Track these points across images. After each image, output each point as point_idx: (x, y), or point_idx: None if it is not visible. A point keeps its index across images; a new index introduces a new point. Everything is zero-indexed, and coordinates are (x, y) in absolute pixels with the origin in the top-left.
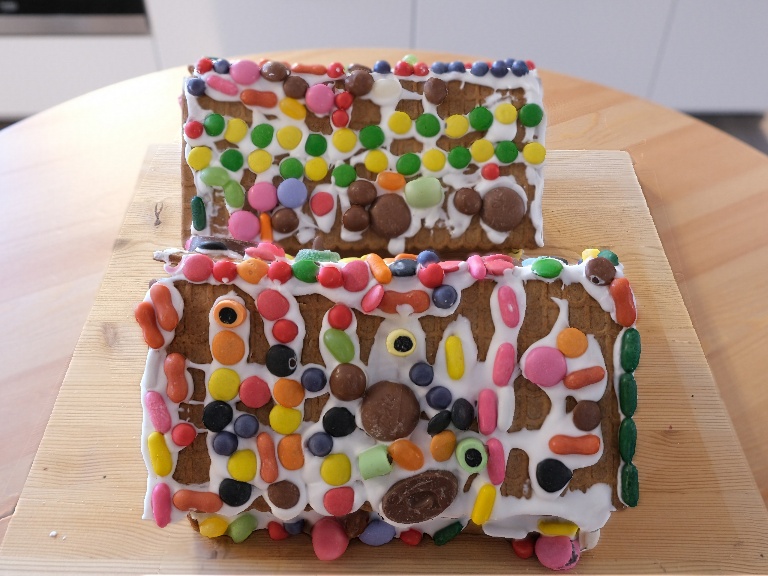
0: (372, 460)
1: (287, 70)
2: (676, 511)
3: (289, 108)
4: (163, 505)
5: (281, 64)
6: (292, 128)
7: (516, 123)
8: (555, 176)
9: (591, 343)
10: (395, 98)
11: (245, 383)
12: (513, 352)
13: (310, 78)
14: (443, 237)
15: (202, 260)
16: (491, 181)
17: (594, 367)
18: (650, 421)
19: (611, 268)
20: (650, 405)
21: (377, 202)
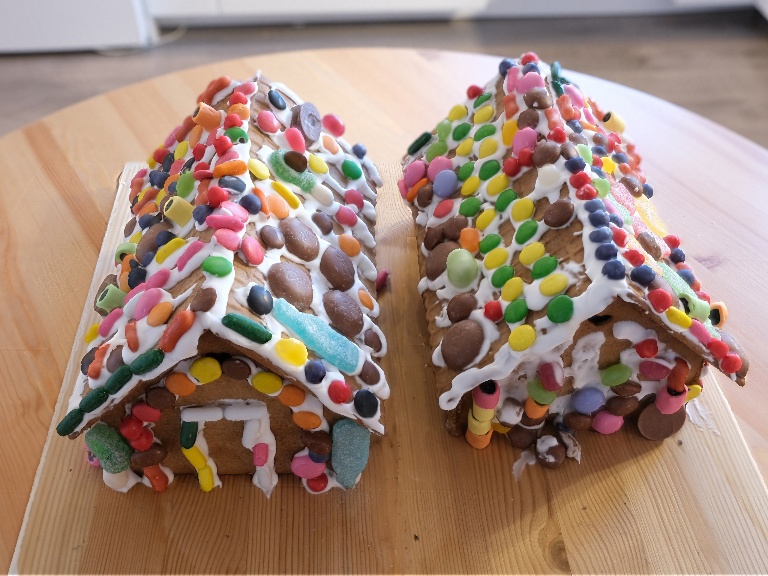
0: (123, 245)
1: (537, 102)
2: (138, 574)
3: (504, 126)
4: (137, 177)
5: (541, 95)
6: (494, 144)
7: (549, 301)
8: (710, 512)
9: (159, 329)
10: (542, 188)
11: (180, 159)
12: (161, 278)
13: (544, 124)
14: (436, 314)
15: (246, 87)
16: (483, 314)
17: (136, 335)
18: (260, 571)
19: (203, 304)
20: (283, 575)
21: (448, 241)
